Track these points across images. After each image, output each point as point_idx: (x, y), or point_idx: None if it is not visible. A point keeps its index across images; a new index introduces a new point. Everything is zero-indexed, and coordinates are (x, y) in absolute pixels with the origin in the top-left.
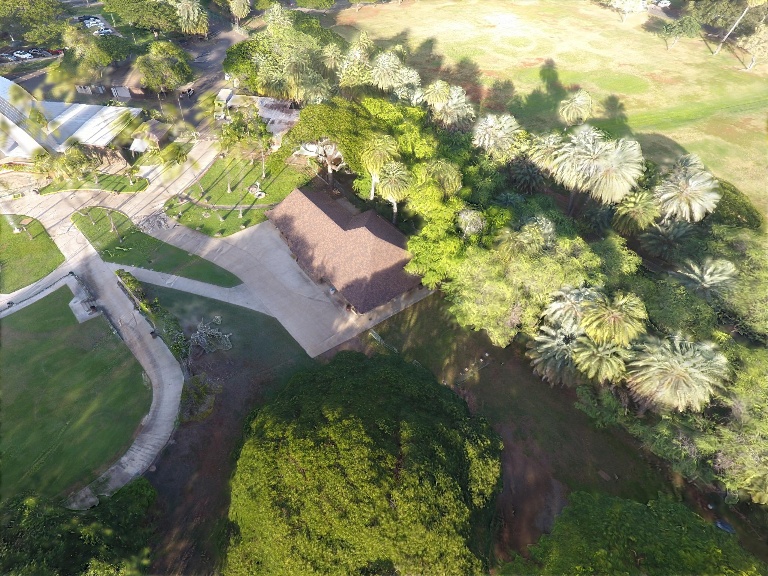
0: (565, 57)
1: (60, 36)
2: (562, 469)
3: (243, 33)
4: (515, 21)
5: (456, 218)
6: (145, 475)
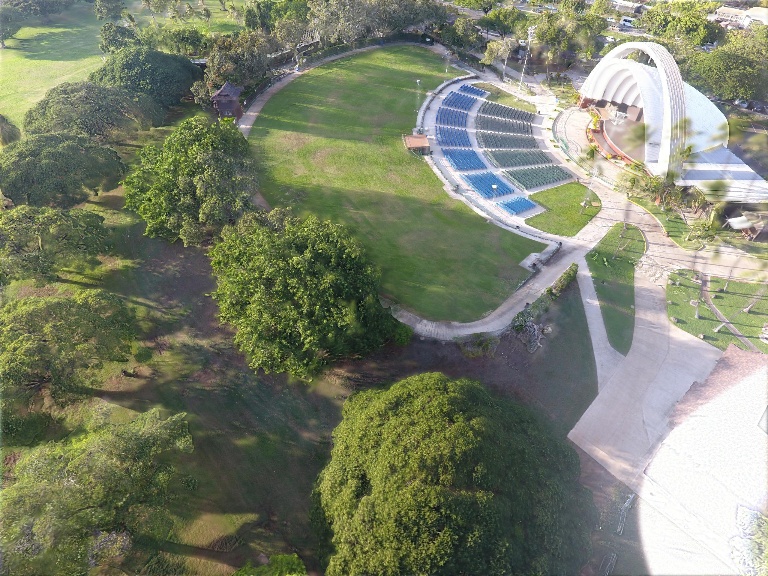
0: None
1: None
2: None
3: None
4: None
5: None
6: (417, 335)
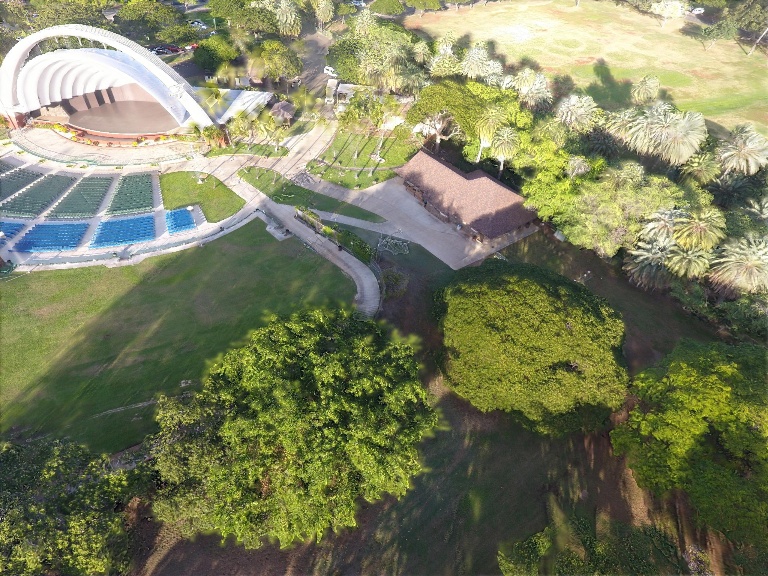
0: (614, 56)
1: (186, 36)
2: (659, 344)
3: (327, 35)
4: (564, 26)
5: (565, 166)
6: None
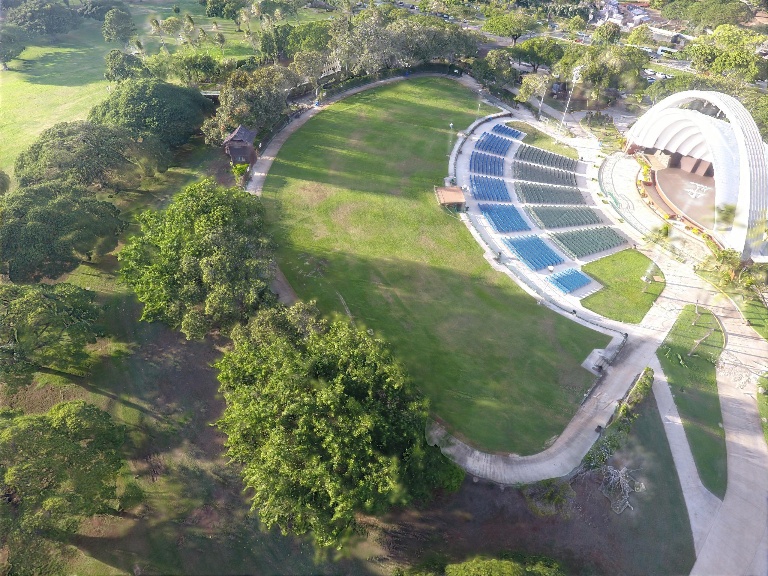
0: None
1: None
2: None
3: None
4: None
5: None
6: (469, 475)
